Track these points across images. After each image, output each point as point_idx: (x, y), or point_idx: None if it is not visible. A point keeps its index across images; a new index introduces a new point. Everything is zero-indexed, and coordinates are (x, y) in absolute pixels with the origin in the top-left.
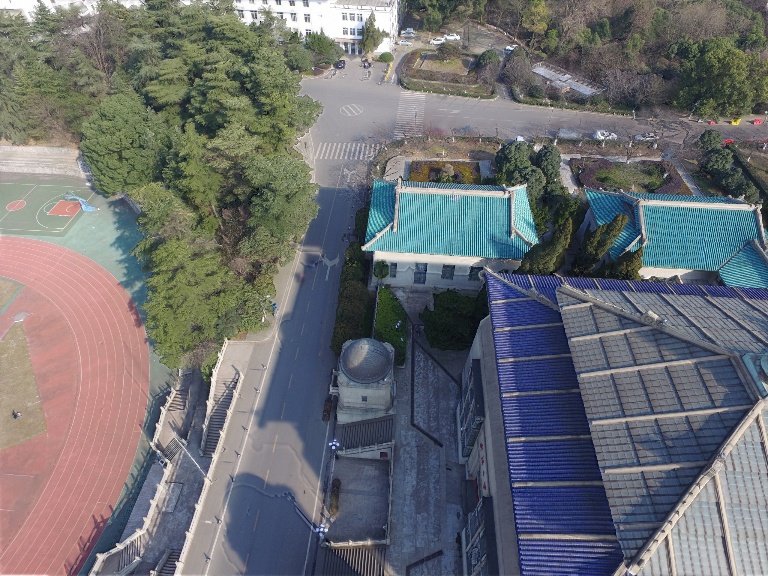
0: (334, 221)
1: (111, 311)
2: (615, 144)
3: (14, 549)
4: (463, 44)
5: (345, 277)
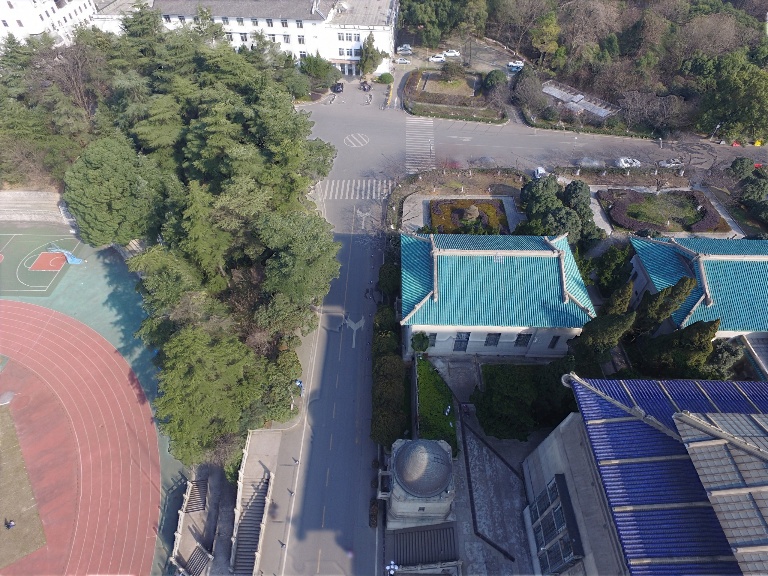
0: (354, 274)
1: (110, 386)
2: (640, 172)
3: None
4: (464, 61)
5: (378, 348)
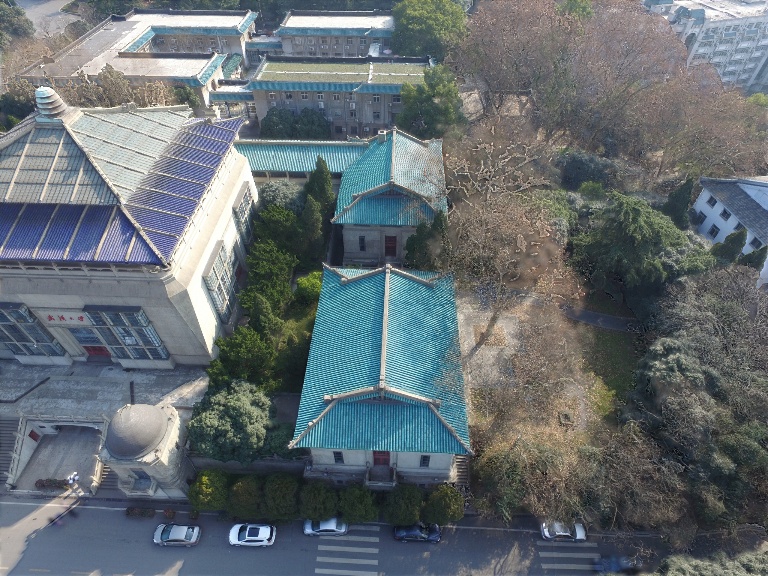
0: None
1: None
2: None
3: None
4: None
5: None
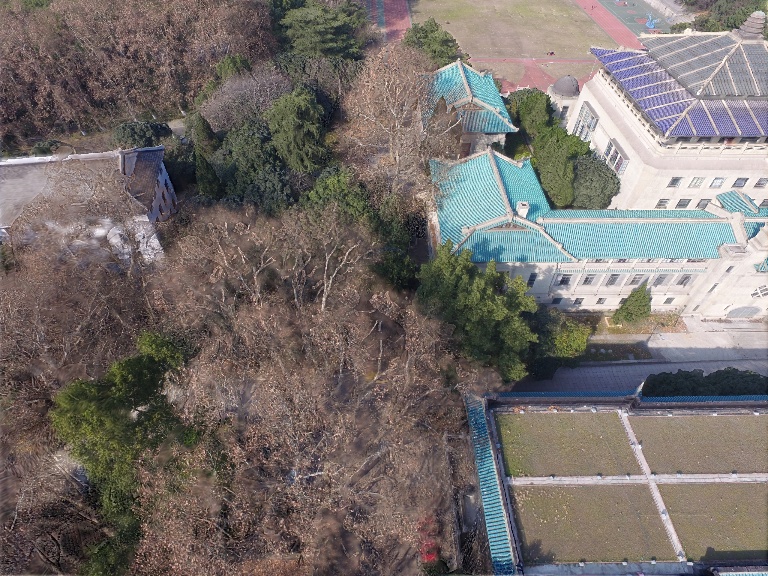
0: None
1: None
2: None
3: None
4: None
5: None
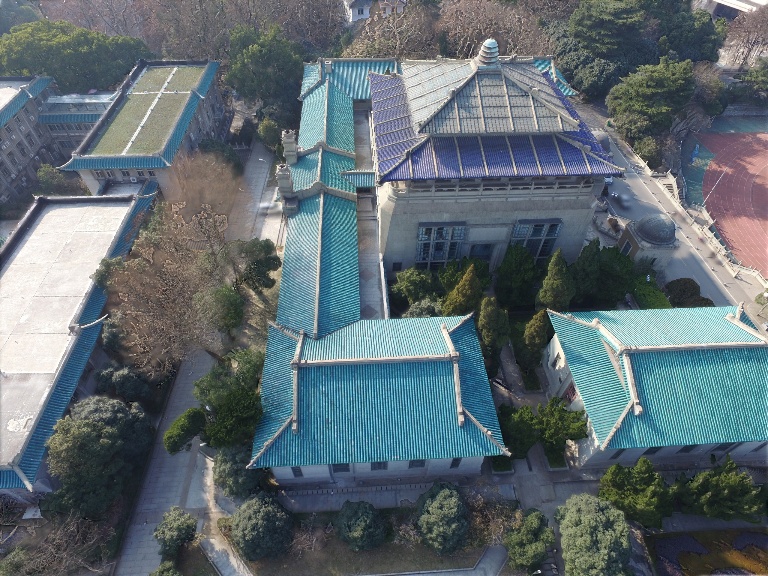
0: None
1: None
2: None
3: (763, 236)
4: None
5: None
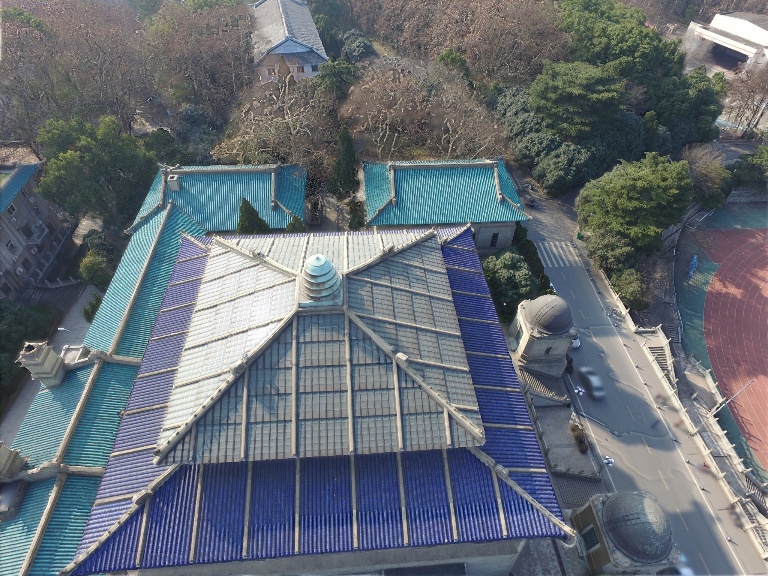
0: None
1: None
2: None
3: None
4: None
5: None
